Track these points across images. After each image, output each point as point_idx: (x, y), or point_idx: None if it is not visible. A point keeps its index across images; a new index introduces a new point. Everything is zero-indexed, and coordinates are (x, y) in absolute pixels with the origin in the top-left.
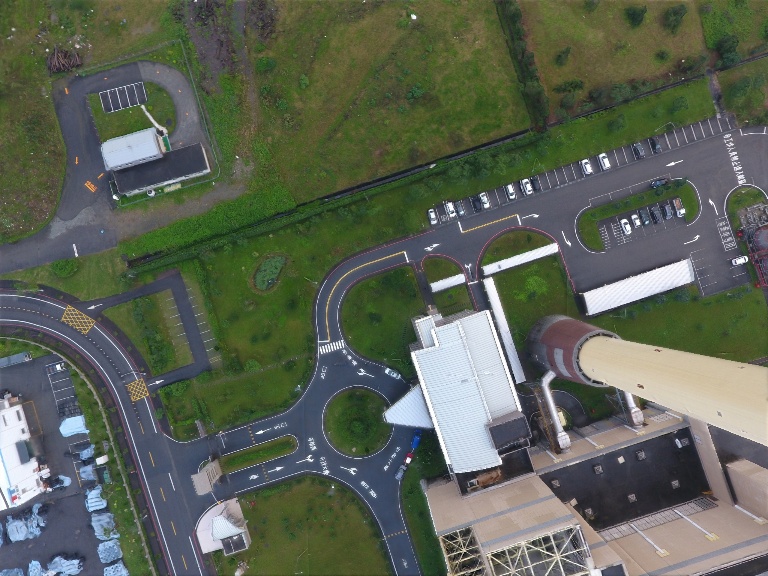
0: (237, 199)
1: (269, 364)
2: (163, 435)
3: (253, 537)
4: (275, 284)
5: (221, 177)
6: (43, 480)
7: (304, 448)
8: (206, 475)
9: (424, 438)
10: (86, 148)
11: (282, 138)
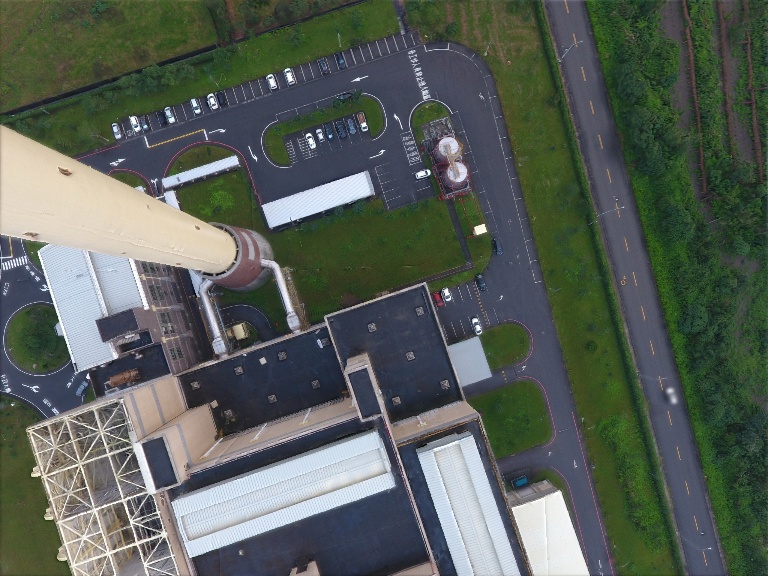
0: None
1: None
2: None
3: None
4: None
5: None
6: None
7: None
8: None
9: None
10: None
11: None
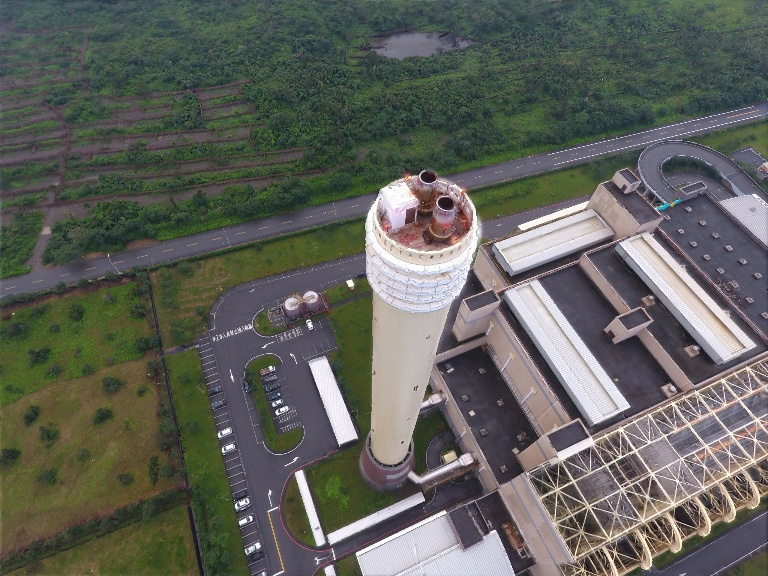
0: None
1: None
2: None
3: None
4: None
5: None
6: None
7: None
8: None
9: None
10: None
11: None
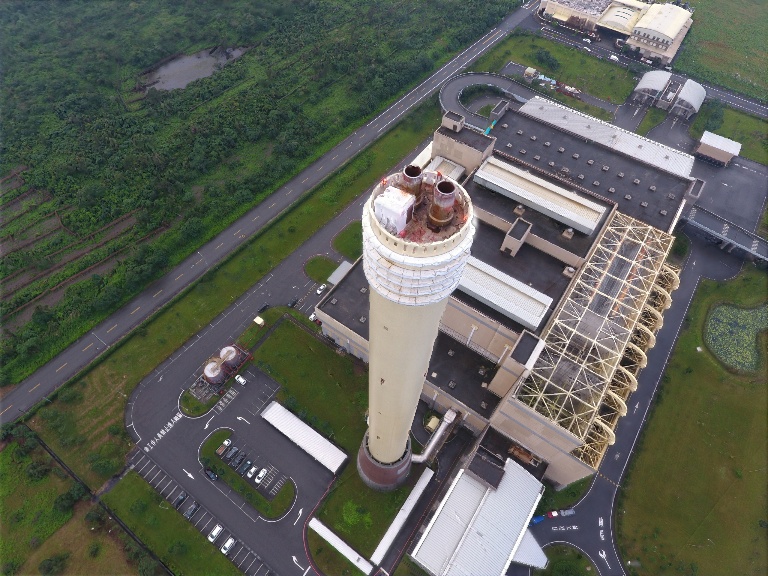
0: None
1: None
2: None
3: None
4: None
5: None
6: None
7: None
8: None
9: None
10: None
11: None
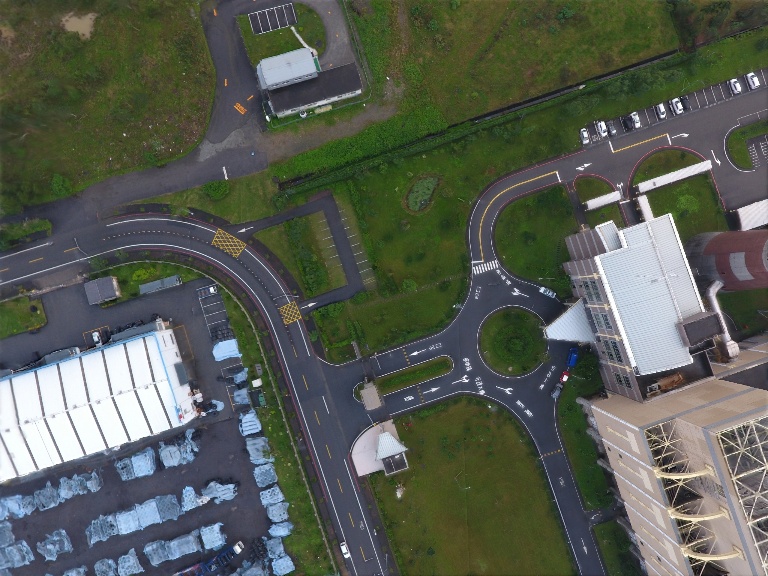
0: (389, 120)
1: (423, 285)
2: (316, 358)
3: (409, 458)
4: (428, 205)
5: (372, 98)
6: (196, 405)
7: (459, 368)
8: (375, 390)
9: (580, 356)
10: (235, 70)
11: (433, 59)
